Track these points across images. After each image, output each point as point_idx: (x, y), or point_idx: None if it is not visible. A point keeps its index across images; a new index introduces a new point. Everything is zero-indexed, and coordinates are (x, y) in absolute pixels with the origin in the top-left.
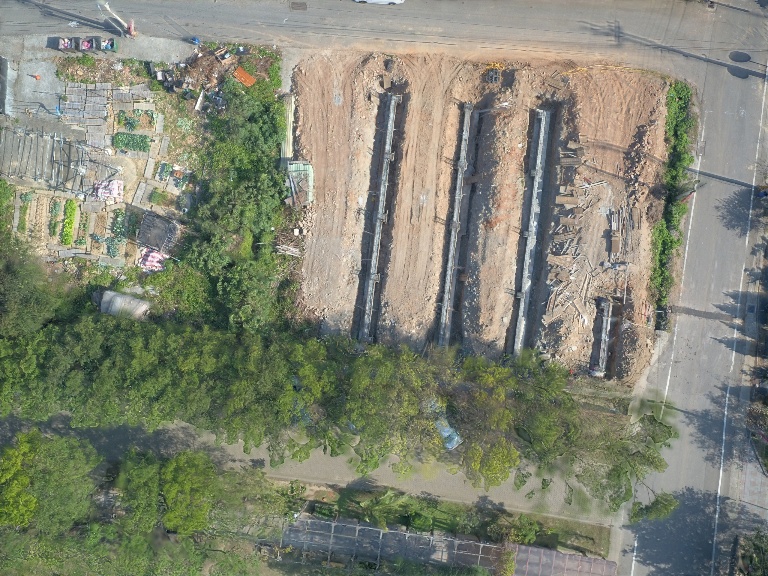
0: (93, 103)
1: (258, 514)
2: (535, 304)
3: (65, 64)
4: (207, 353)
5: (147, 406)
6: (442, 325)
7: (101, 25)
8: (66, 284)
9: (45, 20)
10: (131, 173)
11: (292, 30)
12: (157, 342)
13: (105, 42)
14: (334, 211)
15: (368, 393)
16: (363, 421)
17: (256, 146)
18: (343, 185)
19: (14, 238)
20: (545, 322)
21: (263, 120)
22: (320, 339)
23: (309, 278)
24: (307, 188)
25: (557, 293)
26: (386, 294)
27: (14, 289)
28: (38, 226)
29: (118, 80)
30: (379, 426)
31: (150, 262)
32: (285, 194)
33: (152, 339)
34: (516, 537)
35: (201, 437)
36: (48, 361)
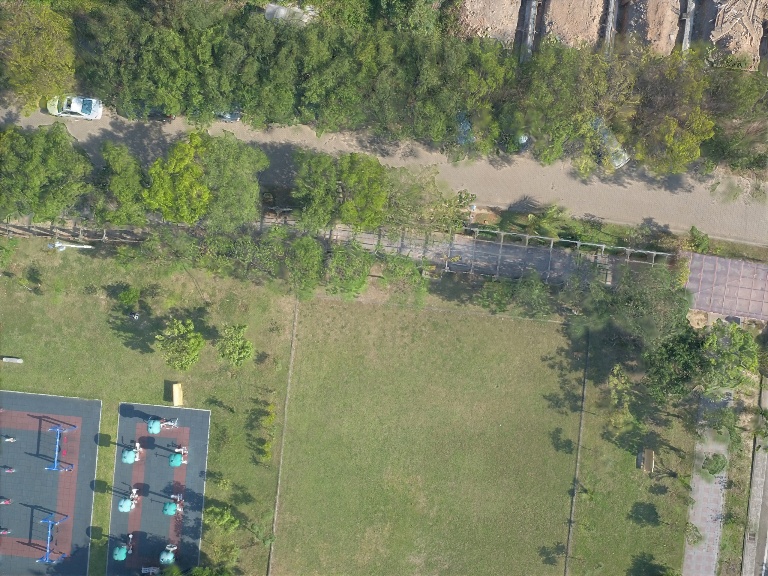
0: None
1: (436, 205)
2: (699, 28)
3: None
4: (384, 45)
5: (322, 98)
6: (607, 45)
7: None
8: None
9: None
10: None
11: None
12: (333, 34)
13: None
14: None
15: (555, 72)
16: (552, 97)
17: None
18: None
19: None
20: (713, 38)
21: None
22: None
23: None
24: None
25: (725, 10)
26: (550, 14)
27: None
28: None
29: None
30: (570, 100)
31: None
32: None
33: (328, 31)
34: (689, 246)
35: None
36: (222, 52)
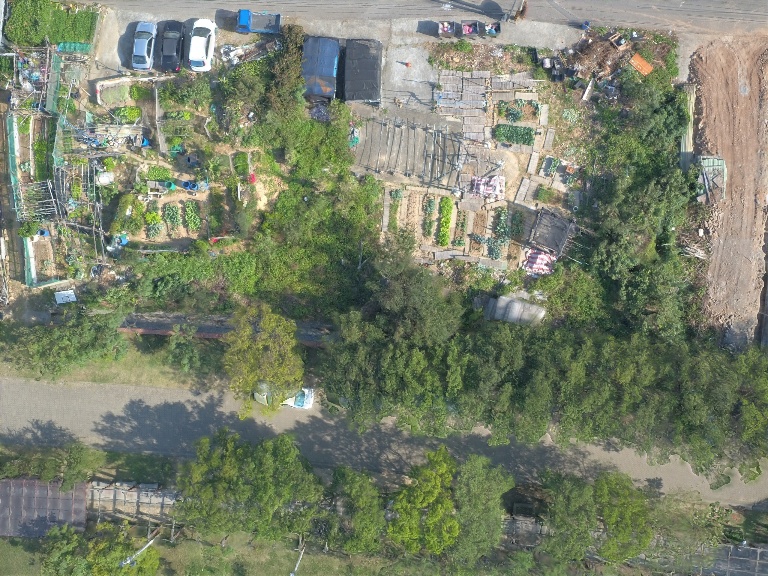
0: (470, 92)
1: (704, 541)
2: None
3: (440, 50)
4: (644, 364)
5: (578, 422)
6: None
7: (478, 8)
8: (443, 288)
9: (415, 3)
10: (513, 168)
11: (689, 14)
12: (588, 352)
13: (488, 26)
14: (743, 210)
15: None
16: None
17: (658, 139)
18: (752, 182)
19: (384, 238)
20: None
21: (667, 111)
22: (724, 348)
23: (715, 282)
24: (722, 185)
25: None
26: None
27: (419, 294)
28: (410, 225)
29: (497, 68)
30: None
31: (538, 265)
32: (696, 191)
33: (583, 349)
34: None
35: (592, 454)
36: (469, 373)
